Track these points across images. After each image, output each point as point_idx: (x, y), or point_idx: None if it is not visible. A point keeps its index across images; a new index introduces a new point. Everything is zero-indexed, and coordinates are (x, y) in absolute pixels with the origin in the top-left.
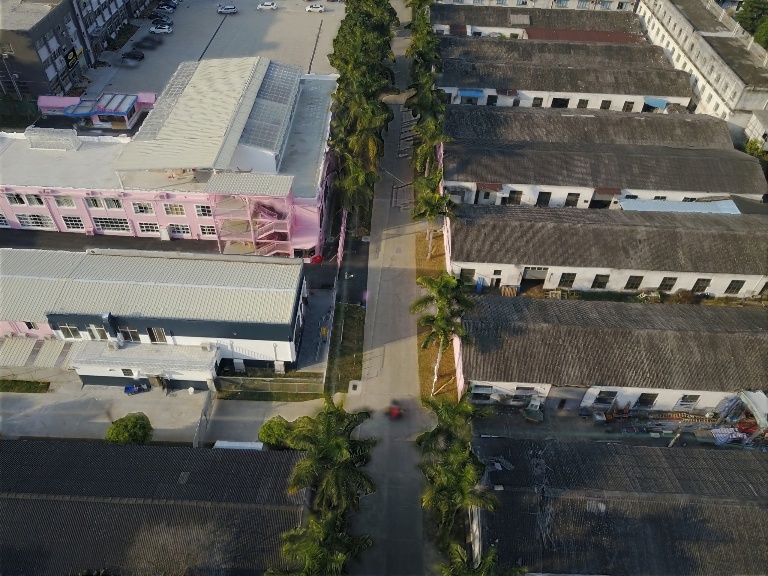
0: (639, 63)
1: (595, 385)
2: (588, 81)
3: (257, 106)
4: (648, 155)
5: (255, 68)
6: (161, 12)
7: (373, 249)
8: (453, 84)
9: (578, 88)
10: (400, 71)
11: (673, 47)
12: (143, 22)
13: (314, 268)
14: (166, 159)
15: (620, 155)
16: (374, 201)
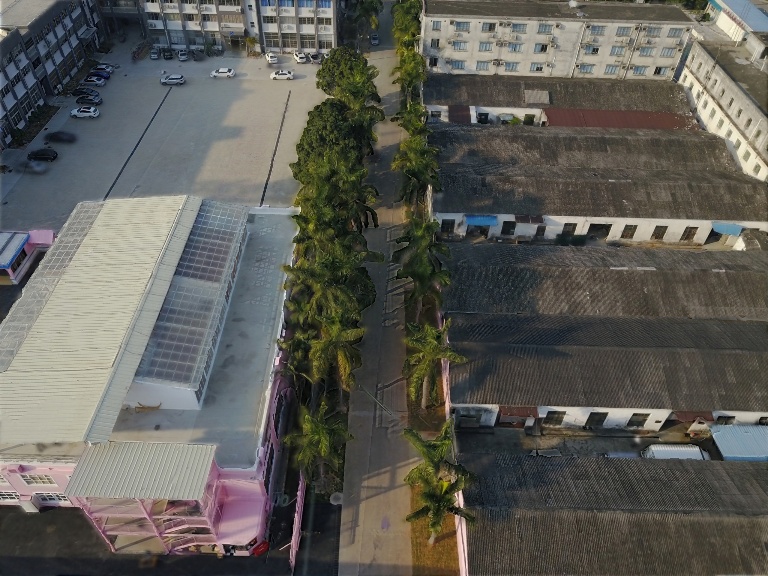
0: (696, 164)
1: None
2: (637, 200)
3: (173, 292)
4: (746, 351)
5: (178, 218)
6: (90, 85)
7: (347, 522)
8: (457, 209)
9: (624, 211)
10: (386, 171)
11: (738, 140)
12: (65, 100)
13: (255, 567)
14: (13, 420)
15: (706, 352)
16: (350, 416)
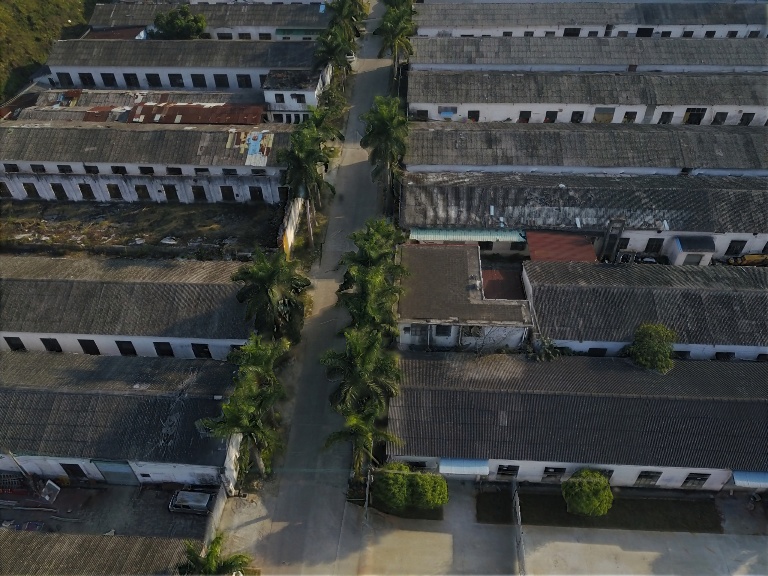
0: None
1: (47, 532)
2: None
3: None
4: None
5: None
6: None
7: None
8: None
9: None
10: None
11: None
12: None
13: None
14: None
15: None
16: None
